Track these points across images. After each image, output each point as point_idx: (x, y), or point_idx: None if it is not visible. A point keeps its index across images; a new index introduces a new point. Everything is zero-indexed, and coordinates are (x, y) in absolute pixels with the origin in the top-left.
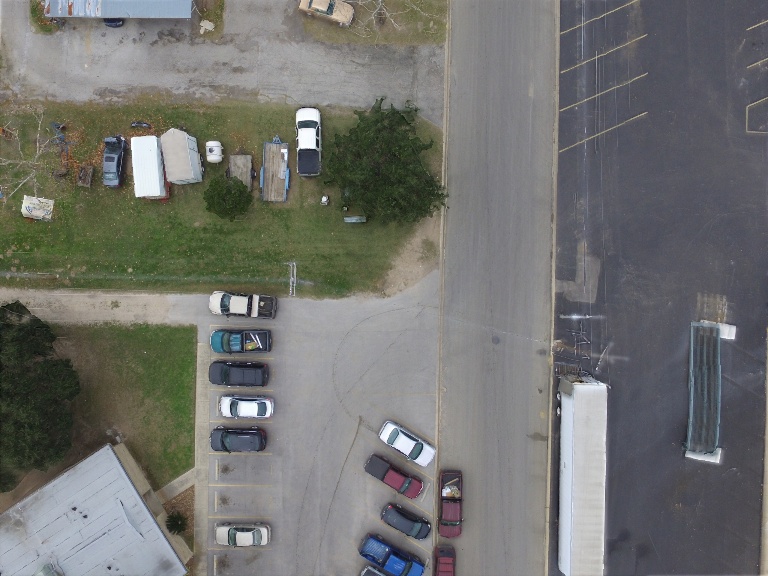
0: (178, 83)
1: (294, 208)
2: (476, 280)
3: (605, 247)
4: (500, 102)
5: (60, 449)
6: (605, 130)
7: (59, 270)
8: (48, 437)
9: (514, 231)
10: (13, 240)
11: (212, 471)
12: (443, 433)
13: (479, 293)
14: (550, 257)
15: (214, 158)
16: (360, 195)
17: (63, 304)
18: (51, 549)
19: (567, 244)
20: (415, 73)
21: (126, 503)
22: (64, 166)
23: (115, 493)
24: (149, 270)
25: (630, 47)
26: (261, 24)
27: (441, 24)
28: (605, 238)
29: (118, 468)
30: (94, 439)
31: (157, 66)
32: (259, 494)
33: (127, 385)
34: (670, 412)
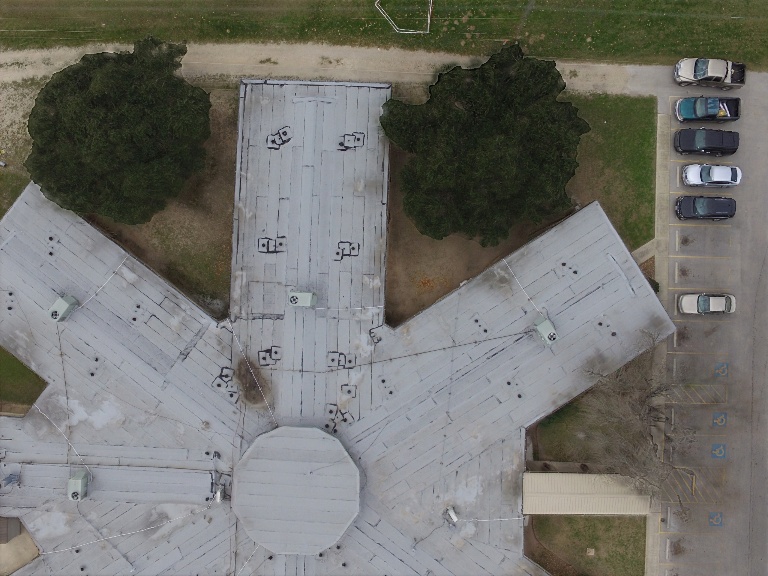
0: None
1: None
2: None
3: None
4: None
5: None
6: None
7: (517, 37)
8: None
9: None
10: (469, 6)
11: (672, 242)
12: None
13: None
14: None
15: None
16: None
17: None
18: (540, 305)
19: None
20: None
21: (617, 258)
22: None
23: (605, 248)
24: (609, 40)
25: None
26: None
27: None
28: None
29: (608, 223)
30: None
31: None
32: (718, 266)
33: (586, 154)
34: None
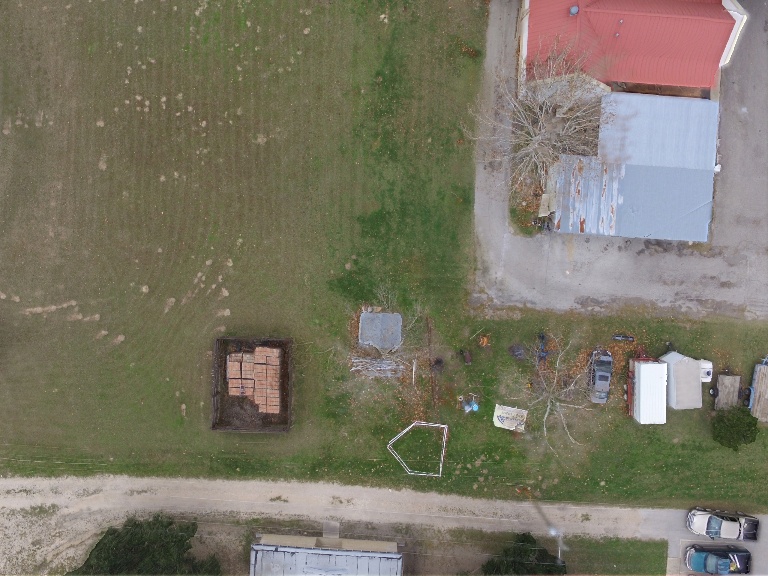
0: (664, 295)
1: None
2: None
3: None
4: None
5: None
6: None
7: (530, 482)
8: None
9: None
10: (482, 450)
11: None
12: None
13: None
14: None
15: (709, 380)
16: None
17: (531, 515)
18: None
19: None
20: None
21: None
22: None
23: None
24: (622, 484)
25: None
26: (750, 237)
27: None
28: None
29: None
30: None
31: (643, 276)
32: None
33: None
34: None
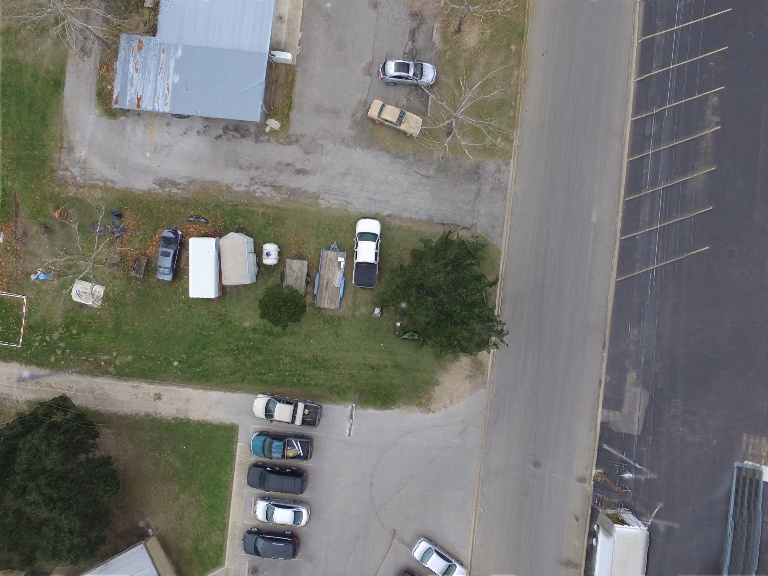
0: (239, 180)
1: (346, 316)
2: (522, 403)
3: (655, 380)
4: (561, 225)
5: (96, 548)
6: (665, 262)
7: (104, 357)
8: (86, 539)
9: (565, 357)
10: (61, 323)
11: (242, 572)
12: (476, 553)
13: (524, 417)
14: (599, 386)
15: (270, 262)
16: (421, 329)
17: (106, 391)
18: None
19: (617, 374)
20: (478, 189)
21: None
22: (118, 253)
23: None
24: (195, 365)
25: (697, 180)
26: (327, 127)
27: (508, 141)
28: (656, 371)
29: (151, 568)
30: (126, 529)
31: (219, 161)
32: None
33: (164, 478)
34: (706, 551)
